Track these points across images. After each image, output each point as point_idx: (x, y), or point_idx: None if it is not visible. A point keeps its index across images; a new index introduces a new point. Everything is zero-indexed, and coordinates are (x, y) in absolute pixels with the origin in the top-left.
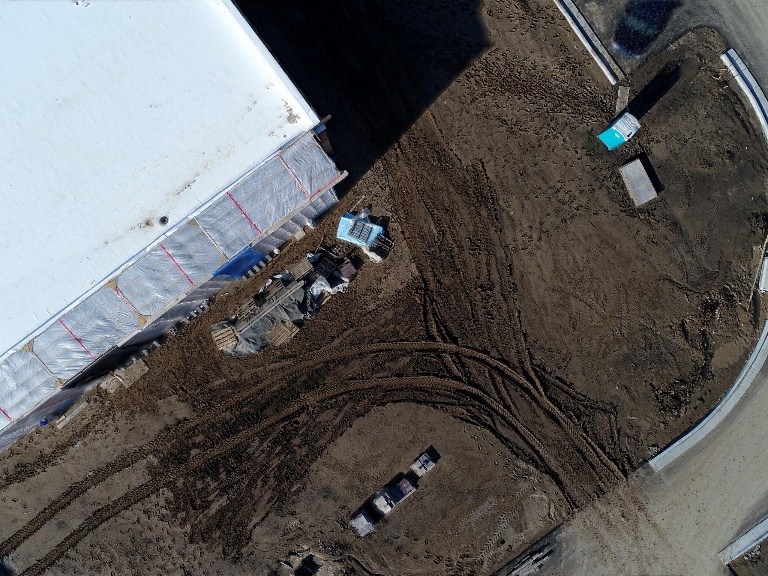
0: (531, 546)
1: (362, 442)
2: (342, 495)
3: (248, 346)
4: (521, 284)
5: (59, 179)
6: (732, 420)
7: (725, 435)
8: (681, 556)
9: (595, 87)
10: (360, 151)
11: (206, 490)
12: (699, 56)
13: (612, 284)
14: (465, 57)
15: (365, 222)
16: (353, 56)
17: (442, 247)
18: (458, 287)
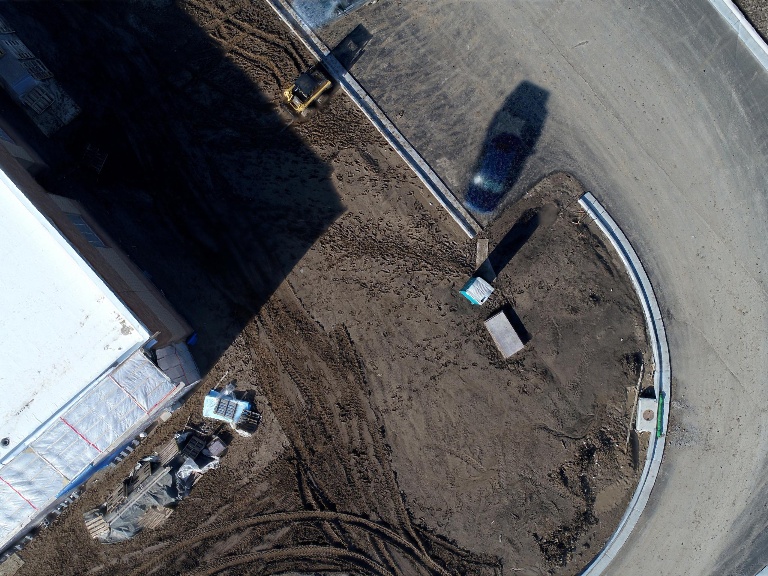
0: None
1: None
2: None
3: (121, 534)
4: (395, 445)
5: None
6: (619, 564)
7: None
8: None
9: (453, 242)
10: (220, 327)
11: None
12: (556, 202)
13: (487, 437)
14: (318, 224)
15: (230, 399)
16: (204, 232)
17: (311, 415)
18: (331, 453)
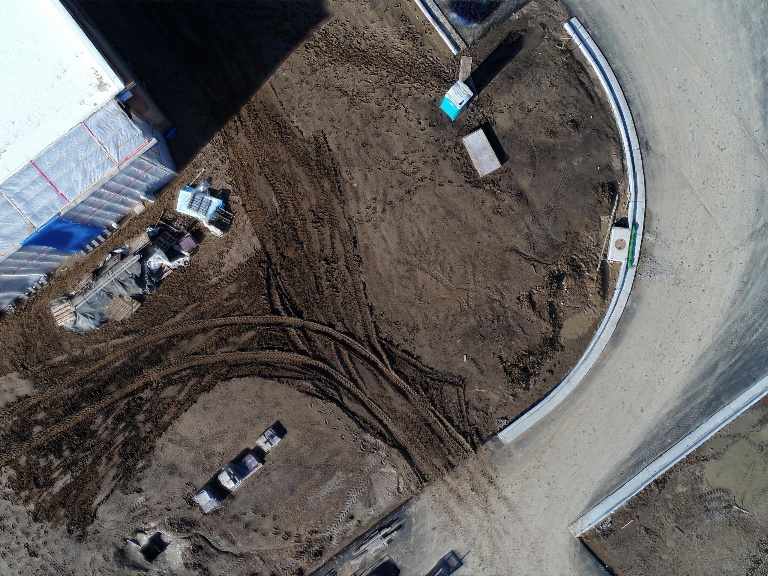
0: (380, 521)
1: (207, 418)
2: (188, 472)
3: (87, 321)
4: (366, 257)
5: None
6: (581, 391)
7: (574, 407)
8: (532, 529)
9: (437, 57)
10: (199, 124)
11: (49, 468)
12: (542, 25)
13: (458, 256)
14: (304, 28)
15: (204, 195)
16: (190, 28)
17: (285, 220)
18: (302, 260)
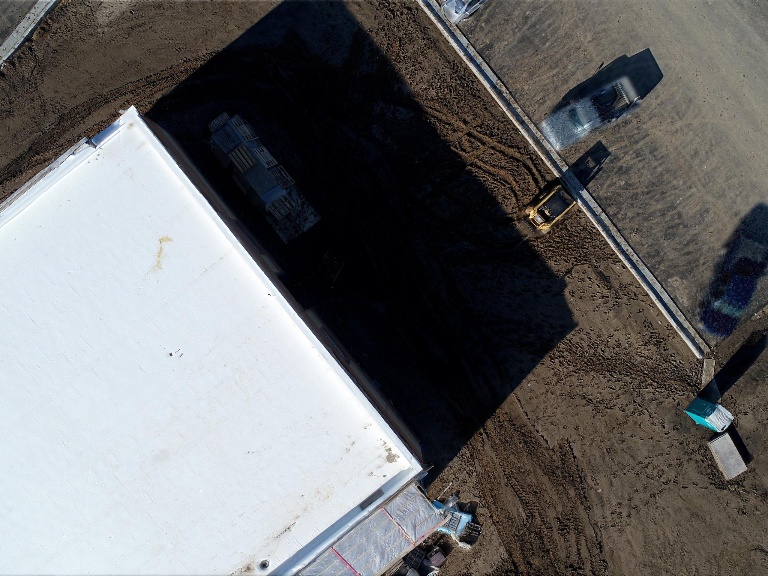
0: None
1: None
2: None
3: None
4: (611, 561)
5: (158, 529)
6: None
7: None
8: None
9: (680, 361)
10: (446, 438)
11: None
12: None
13: (703, 557)
14: (548, 339)
15: (454, 511)
16: (436, 344)
17: (531, 529)
18: (548, 567)
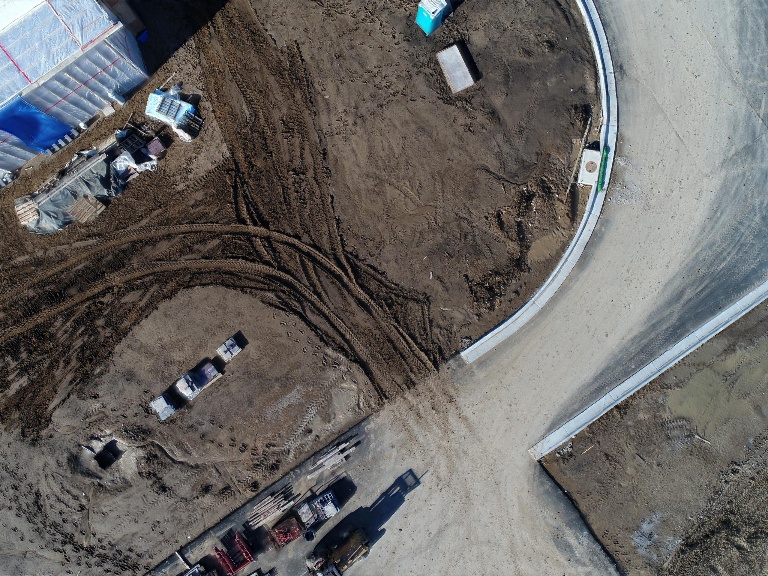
0: (339, 437)
1: (168, 325)
2: (146, 379)
3: (50, 220)
4: (335, 169)
5: None
6: (547, 314)
7: (539, 329)
8: (491, 451)
9: None
10: (172, 27)
11: (6, 369)
12: None
13: (428, 172)
14: None
15: (174, 98)
16: None
17: (254, 128)
18: (270, 170)
